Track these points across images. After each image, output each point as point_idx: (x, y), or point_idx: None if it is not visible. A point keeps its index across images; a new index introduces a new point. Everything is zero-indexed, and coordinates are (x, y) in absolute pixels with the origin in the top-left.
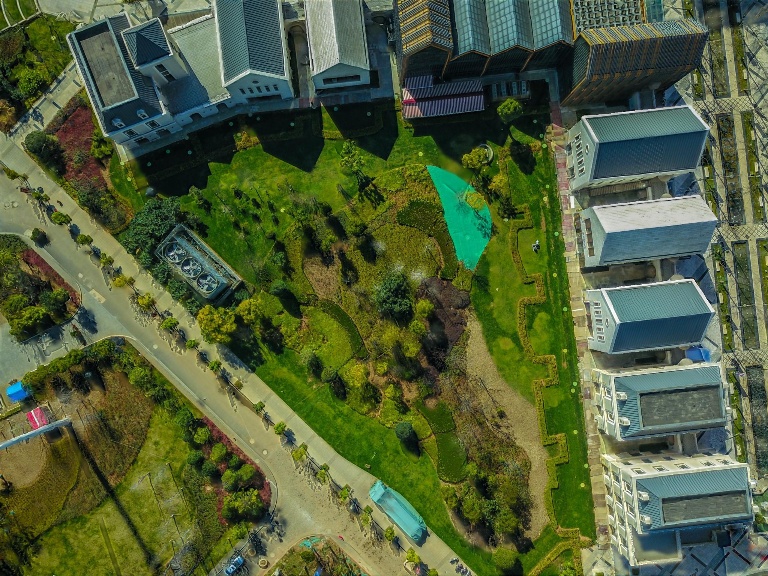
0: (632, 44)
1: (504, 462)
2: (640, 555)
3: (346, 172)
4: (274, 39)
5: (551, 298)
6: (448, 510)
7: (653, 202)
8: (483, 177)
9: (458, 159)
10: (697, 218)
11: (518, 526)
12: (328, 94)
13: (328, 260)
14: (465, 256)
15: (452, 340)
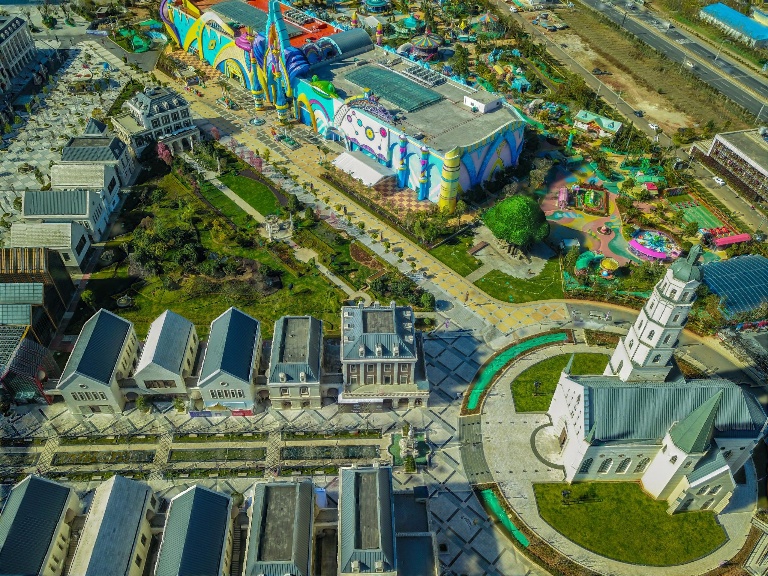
0: None
1: None
2: (430, 574)
3: None
4: None
5: None
6: None
7: (83, 530)
8: None
9: None
10: (108, 492)
11: None
12: None
13: None
14: None
15: None
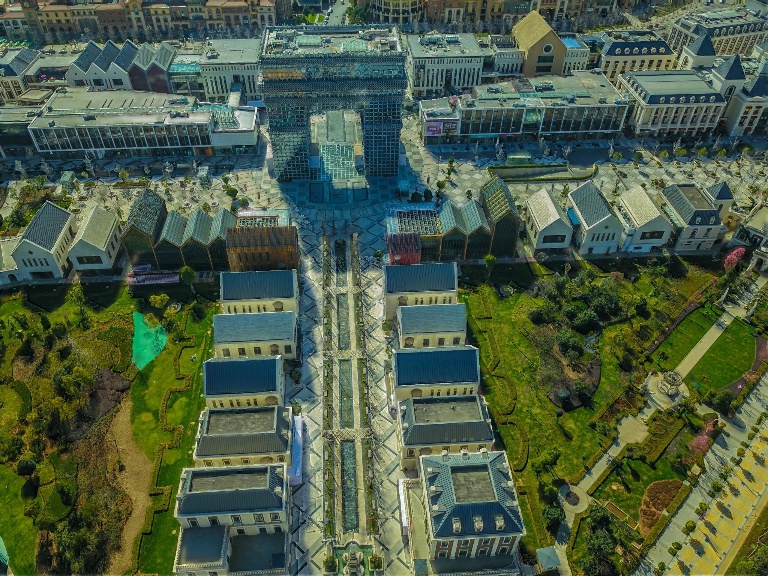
0: (249, 229)
1: (107, 506)
2: (185, 561)
3: (76, 313)
4: (53, 236)
5: (193, 388)
6: (36, 549)
7: None
8: (170, 320)
9: (157, 310)
10: None
11: (98, 569)
12: (86, 277)
13: (35, 358)
14: (138, 361)
15: (103, 411)
